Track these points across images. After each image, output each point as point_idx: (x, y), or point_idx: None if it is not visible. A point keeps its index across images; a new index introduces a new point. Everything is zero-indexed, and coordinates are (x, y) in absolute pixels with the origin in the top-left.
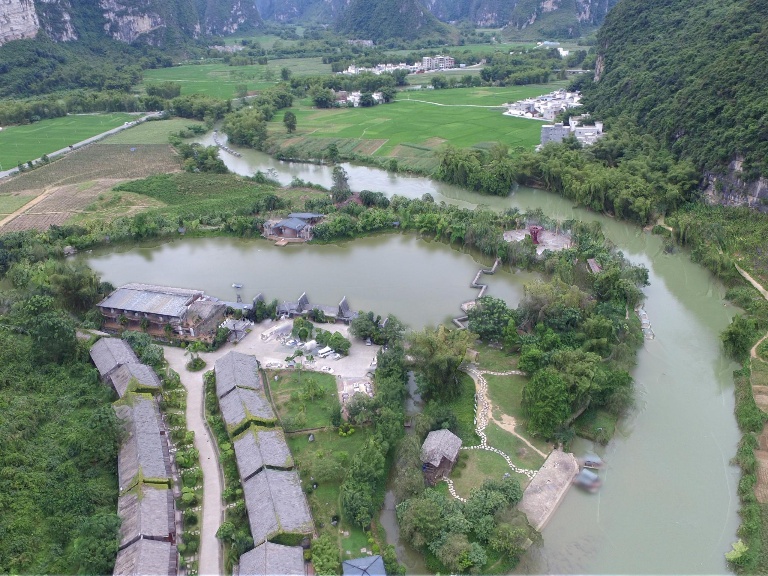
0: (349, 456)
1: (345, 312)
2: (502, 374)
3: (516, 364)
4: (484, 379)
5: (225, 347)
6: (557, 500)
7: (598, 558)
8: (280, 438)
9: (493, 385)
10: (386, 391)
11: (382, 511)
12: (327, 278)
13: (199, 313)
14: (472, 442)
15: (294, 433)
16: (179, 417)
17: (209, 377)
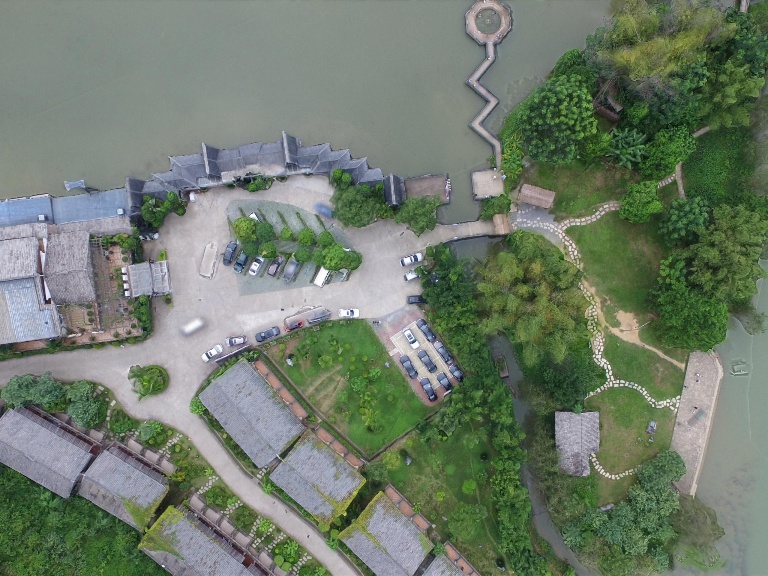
0: (467, 469)
1: (298, 160)
2: (593, 220)
3: (605, 186)
4: (572, 242)
5: (159, 314)
6: (707, 430)
7: (757, 488)
8: (392, 512)
9: (588, 253)
10: (472, 364)
11: (534, 518)
12: (175, 8)
13: (75, 293)
14: (598, 385)
15: (381, 457)
16: (221, 494)
17: (203, 413)
